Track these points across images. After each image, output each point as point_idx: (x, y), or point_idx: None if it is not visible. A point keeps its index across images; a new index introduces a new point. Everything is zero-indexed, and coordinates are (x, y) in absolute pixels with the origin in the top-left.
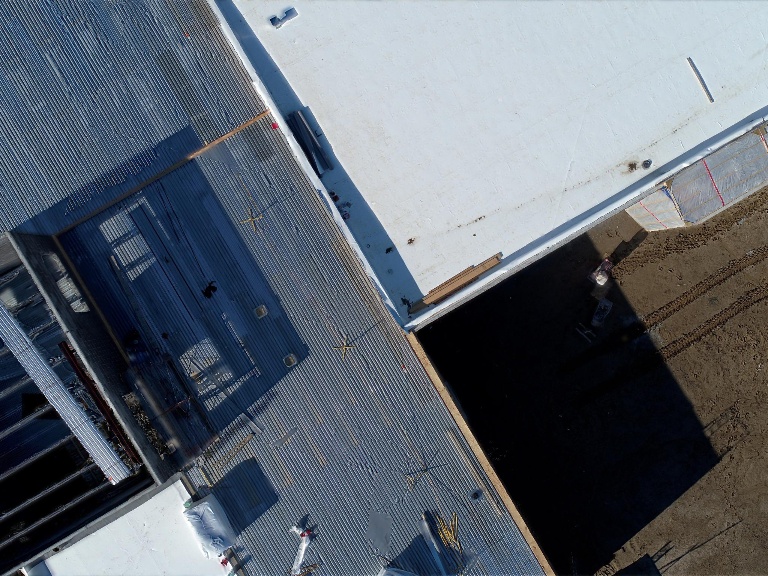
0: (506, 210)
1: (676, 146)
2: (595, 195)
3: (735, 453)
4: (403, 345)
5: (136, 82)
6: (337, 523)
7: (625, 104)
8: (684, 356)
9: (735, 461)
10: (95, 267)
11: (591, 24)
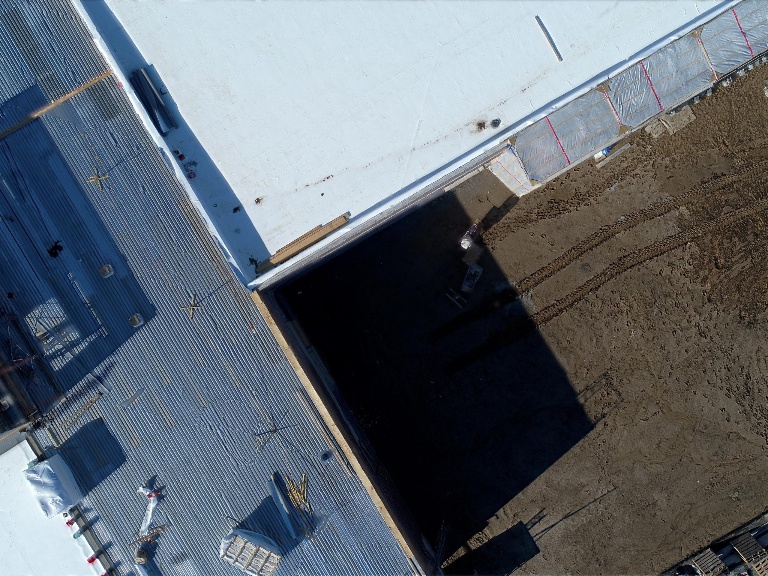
0: (354, 169)
1: (525, 105)
2: (444, 154)
3: (609, 420)
4: (251, 305)
5: None
6: (185, 484)
7: (473, 63)
8: (557, 322)
9: (609, 428)
10: None
11: None
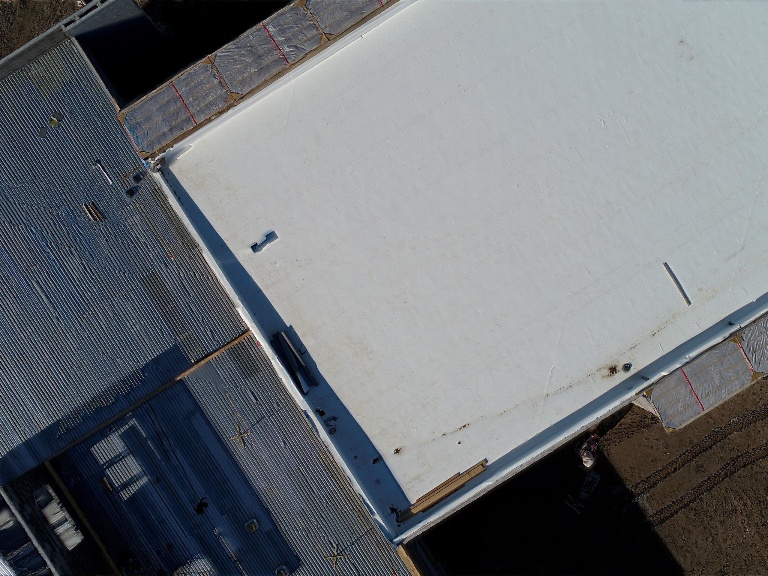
0: (489, 417)
1: (655, 349)
2: (577, 399)
3: None
4: (393, 552)
5: (122, 304)
6: None
7: (603, 310)
8: (672, 523)
9: None
10: (88, 488)
11: (567, 234)
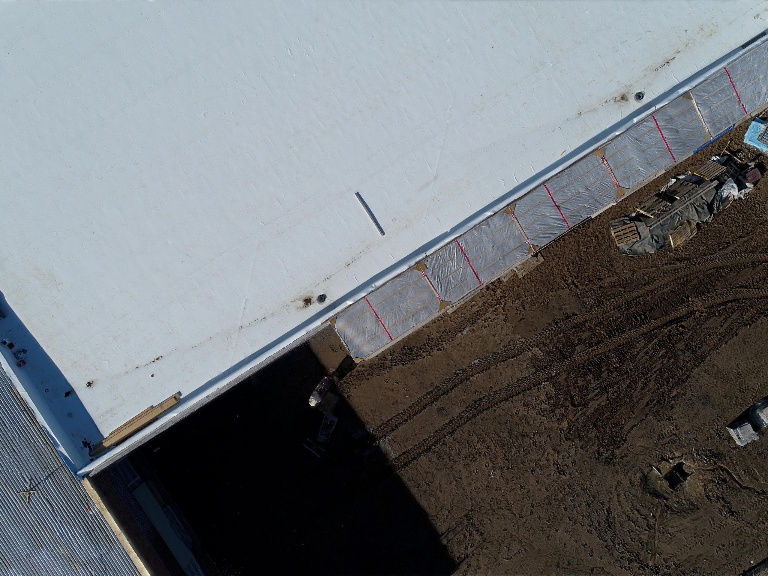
0: (183, 350)
1: (350, 280)
2: (271, 331)
3: (472, 560)
4: None
5: None
6: None
7: (296, 241)
8: (415, 466)
9: (473, 568)
10: None
11: (256, 164)
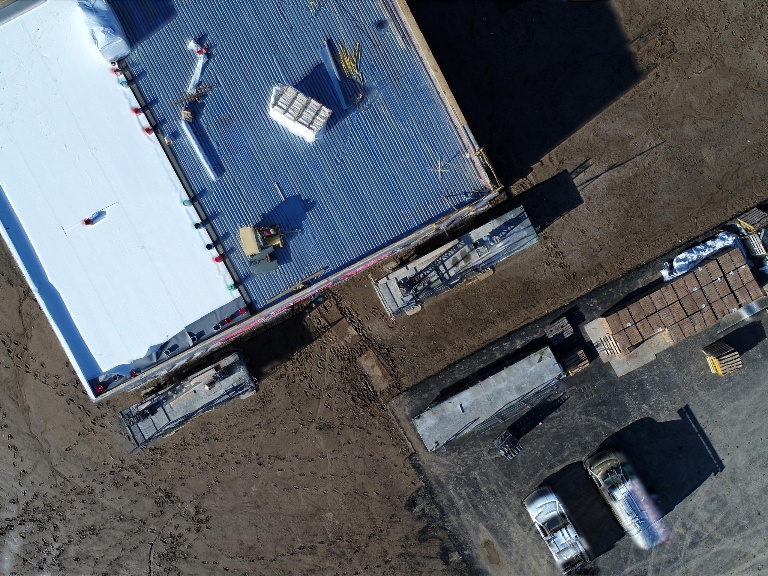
0: None
1: None
2: None
3: (661, 71)
4: None
5: None
6: (237, 45)
7: None
8: None
9: (661, 79)
10: None
11: None
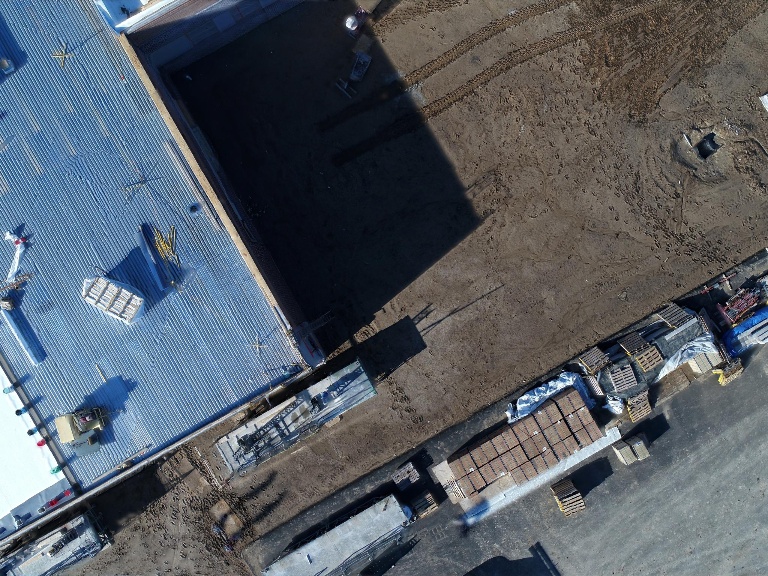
0: None
1: None
2: None
3: (498, 216)
4: (123, 56)
5: None
6: (54, 233)
7: None
8: (446, 116)
9: (498, 224)
10: None
11: None
